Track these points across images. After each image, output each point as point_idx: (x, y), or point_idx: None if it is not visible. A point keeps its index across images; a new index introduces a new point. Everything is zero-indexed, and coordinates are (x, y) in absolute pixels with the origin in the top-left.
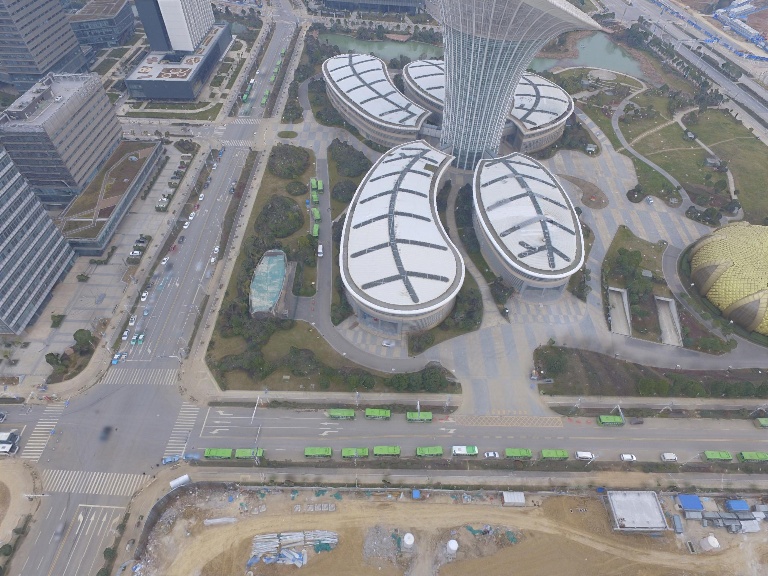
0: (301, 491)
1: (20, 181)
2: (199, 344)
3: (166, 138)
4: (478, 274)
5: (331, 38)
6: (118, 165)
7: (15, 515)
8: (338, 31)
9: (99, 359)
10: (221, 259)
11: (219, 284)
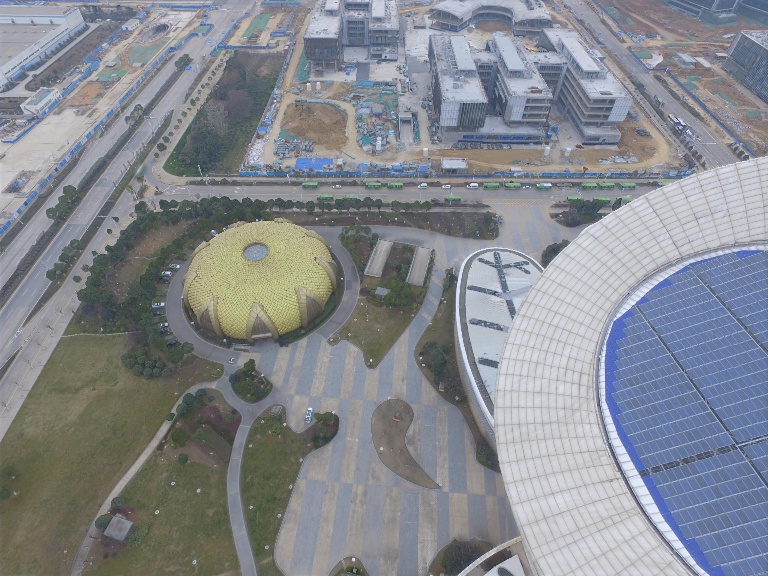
0: None
1: None
2: None
3: None
4: None
5: None
6: None
7: None
8: None
9: None
10: None
11: None
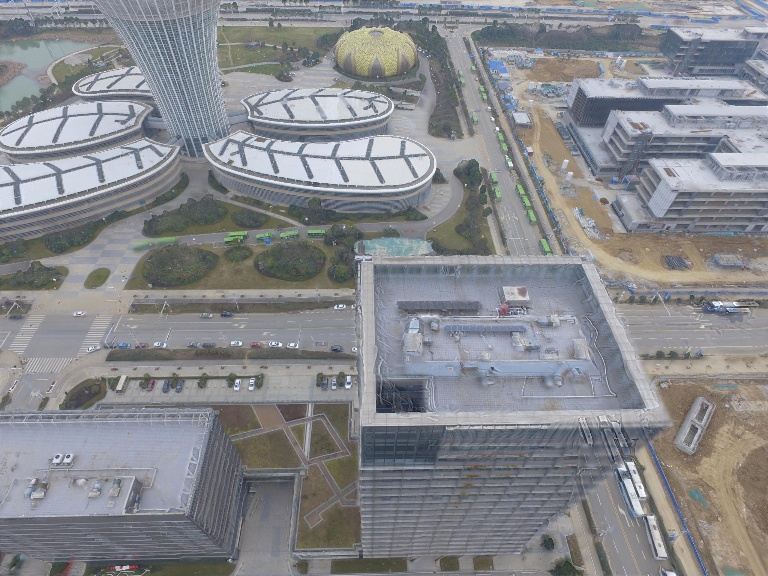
0: None
1: None
2: None
3: None
4: None
5: None
6: None
7: None
8: None
9: None
10: None
11: None
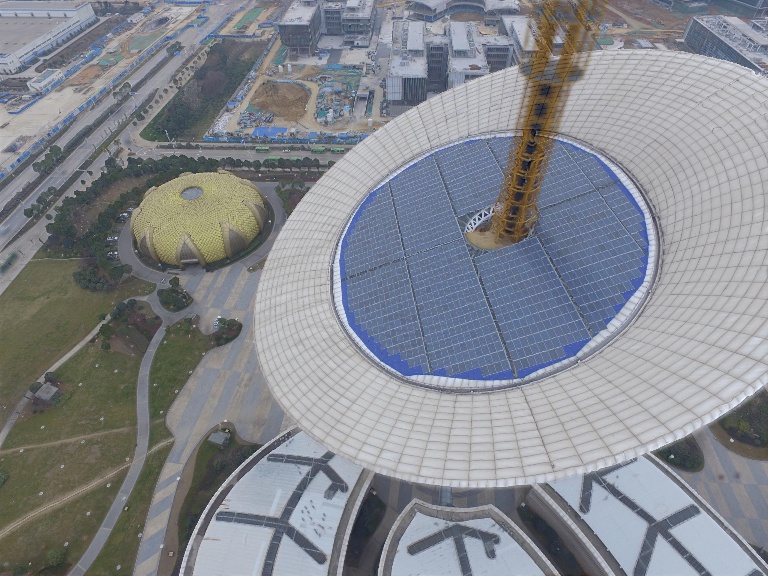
0: None
1: None
2: None
3: None
4: None
5: None
6: None
7: None
8: None
9: None
10: None
11: None
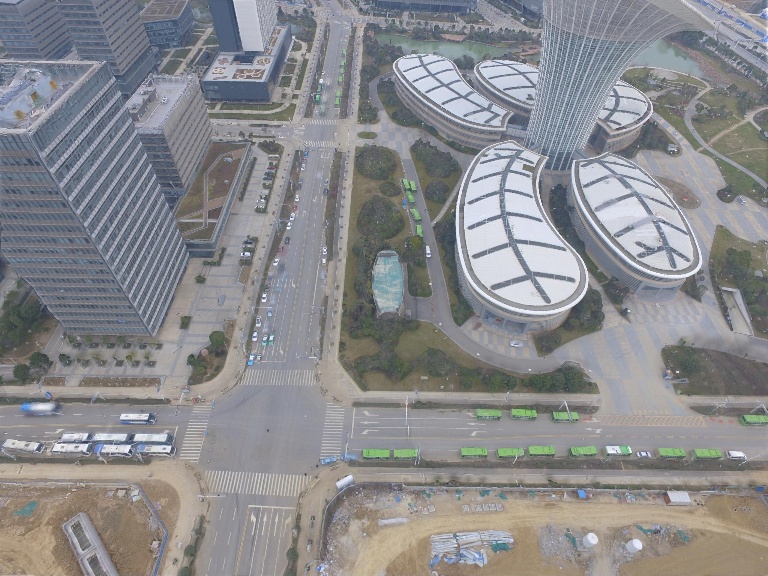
0: (465, 491)
1: (156, 183)
2: (329, 345)
3: (250, 139)
4: (588, 274)
5: (386, 38)
6: (214, 166)
7: (188, 516)
8: (393, 31)
9: (234, 360)
10: (331, 260)
11: (335, 285)
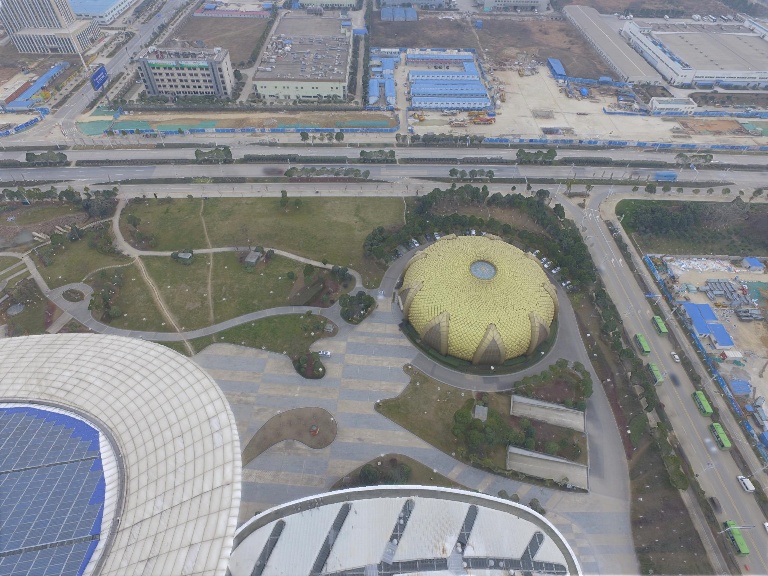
0: None
1: None
2: None
3: None
4: None
5: None
6: None
7: None
8: None
9: None
10: None
11: None
